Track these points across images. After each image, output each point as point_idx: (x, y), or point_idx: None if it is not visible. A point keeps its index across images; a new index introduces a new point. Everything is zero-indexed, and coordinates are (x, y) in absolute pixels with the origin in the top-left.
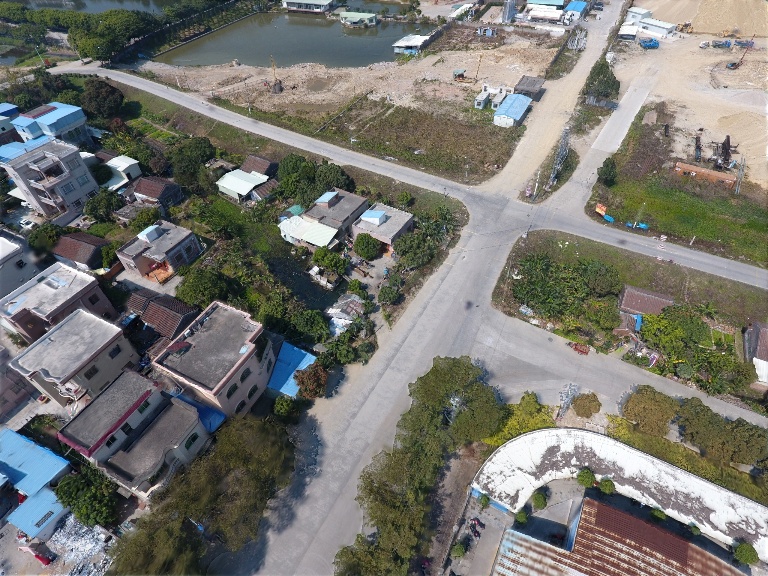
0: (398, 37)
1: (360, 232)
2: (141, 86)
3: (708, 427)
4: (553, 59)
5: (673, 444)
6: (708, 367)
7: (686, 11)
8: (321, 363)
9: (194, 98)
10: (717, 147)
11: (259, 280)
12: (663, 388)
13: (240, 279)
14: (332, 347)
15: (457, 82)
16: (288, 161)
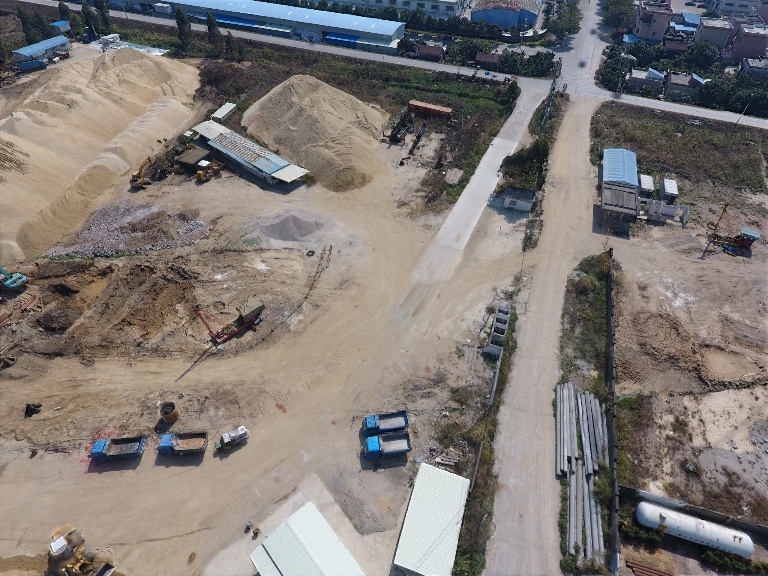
0: None
1: None
2: None
3: None
4: None
5: None
6: None
7: None
8: None
9: None
10: None
11: None
12: None
13: None
14: None
15: None
16: None
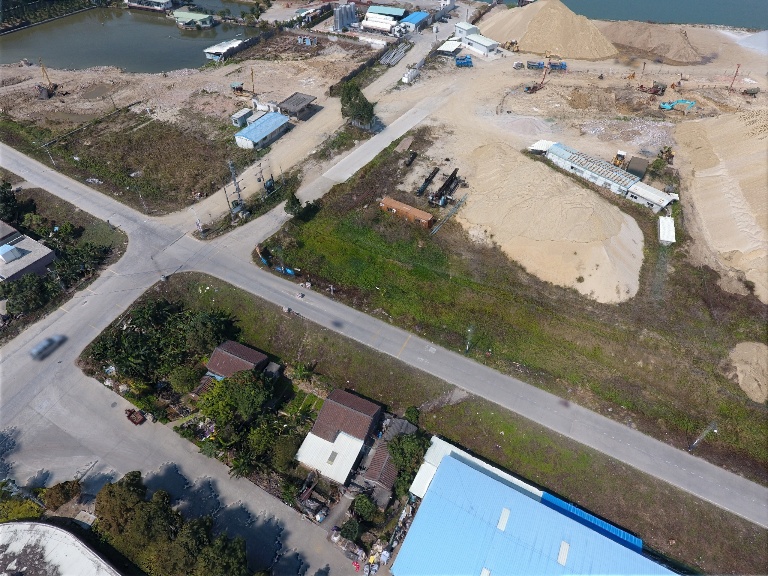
0: (217, 42)
1: None
2: None
3: (137, 532)
4: None
5: None
6: None
7: (517, 29)
8: None
9: None
10: None
11: None
12: (197, 467)
13: None
14: None
15: (235, 95)
16: None
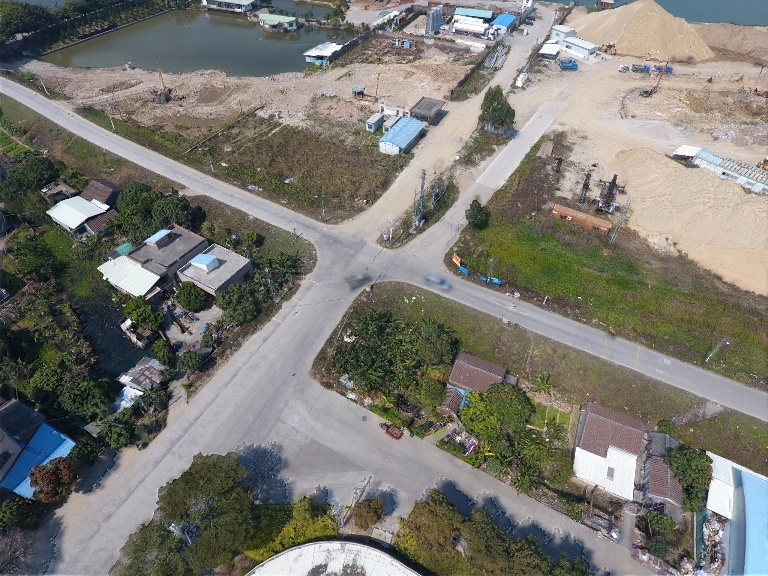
0: (313, 45)
1: (186, 280)
2: (7, 90)
3: (481, 553)
4: (463, 78)
5: (463, 558)
6: (524, 459)
7: (612, 31)
8: (75, 454)
9: (61, 107)
10: (605, 186)
11: (61, 334)
12: (472, 483)
13: (34, 334)
14: (104, 428)
15: (356, 100)
16: (127, 191)
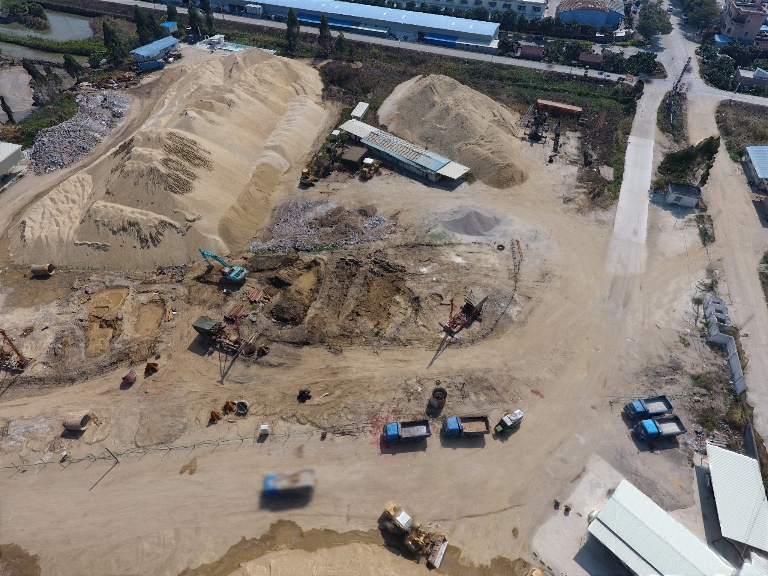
0: None
1: None
2: None
3: None
4: None
5: None
6: None
7: None
8: None
9: None
10: None
11: None
12: None
13: None
14: None
15: None
16: None
